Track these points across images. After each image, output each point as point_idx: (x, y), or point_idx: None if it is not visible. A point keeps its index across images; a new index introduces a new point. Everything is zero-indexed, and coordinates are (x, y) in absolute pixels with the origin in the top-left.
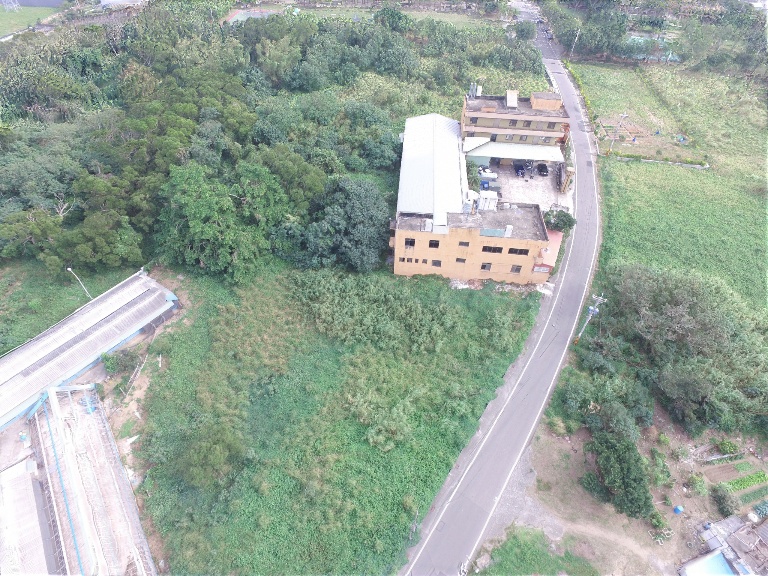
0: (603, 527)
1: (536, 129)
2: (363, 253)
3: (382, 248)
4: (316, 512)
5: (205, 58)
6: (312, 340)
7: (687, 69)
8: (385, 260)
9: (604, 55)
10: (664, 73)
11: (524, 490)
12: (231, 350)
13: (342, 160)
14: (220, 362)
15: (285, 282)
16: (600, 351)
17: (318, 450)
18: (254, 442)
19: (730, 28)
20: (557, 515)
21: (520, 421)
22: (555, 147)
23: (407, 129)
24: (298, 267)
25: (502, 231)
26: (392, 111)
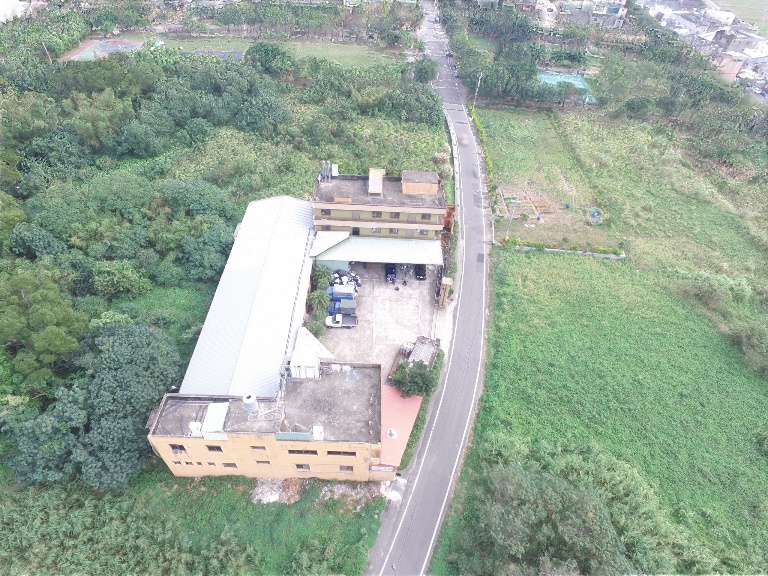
0: None
1: (408, 220)
2: (105, 467)
3: (147, 446)
4: None
5: None
6: None
7: (606, 115)
8: None
9: (515, 98)
10: (581, 120)
11: None
12: None
13: (145, 272)
14: None
15: None
16: None
17: None
18: None
19: (652, 65)
20: None
21: None
22: (434, 241)
23: (245, 220)
24: (17, 482)
25: (308, 434)
26: (239, 187)
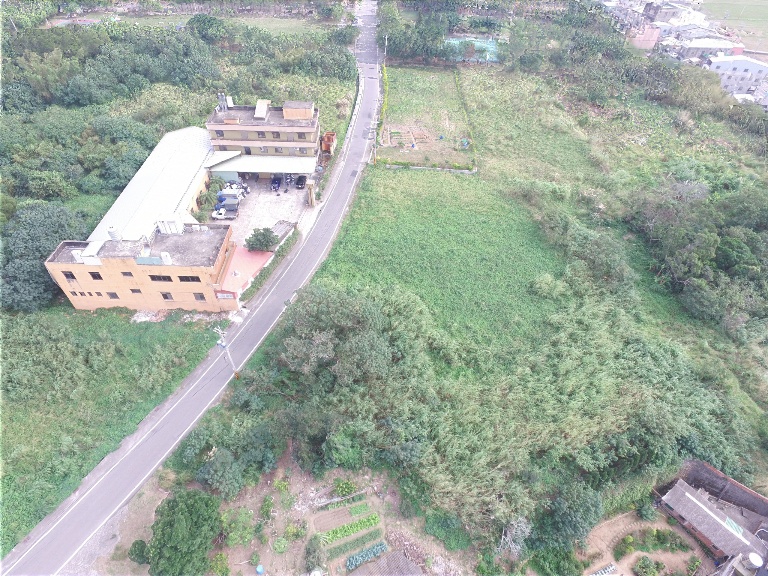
0: None
1: (287, 140)
2: (17, 290)
3: (52, 282)
4: None
5: None
6: None
7: (504, 70)
8: None
9: None
10: None
11: (92, 562)
12: None
13: (72, 182)
14: None
15: None
16: (248, 386)
17: None
18: None
19: (553, 28)
20: None
21: (129, 476)
22: (311, 158)
23: (159, 145)
24: None
25: (158, 259)
26: (162, 125)
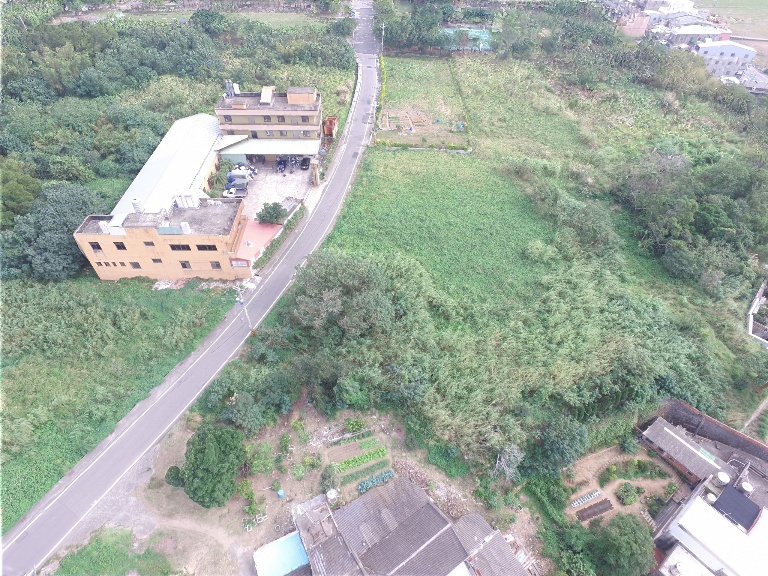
0: (199, 520)
1: (292, 124)
2: (48, 260)
3: (79, 254)
4: None
5: None
6: None
7: (497, 58)
8: None
9: None
10: (475, 62)
11: (131, 490)
12: None
13: (90, 166)
14: None
15: None
16: (264, 341)
17: None
18: None
19: (544, 16)
20: (155, 512)
21: (160, 419)
22: (315, 140)
23: (170, 131)
24: None
25: (178, 228)
26: (171, 113)
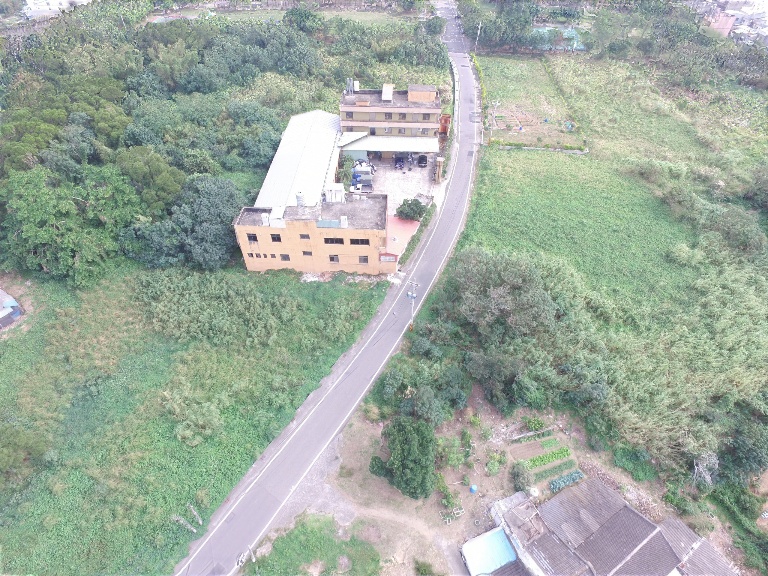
0: (396, 510)
1: (412, 121)
2: (206, 250)
3: (231, 245)
4: (104, 510)
5: (96, 64)
6: (148, 339)
7: (591, 57)
8: (241, 257)
9: (512, 47)
10: (569, 62)
11: (324, 477)
12: (63, 353)
13: (218, 160)
14: (49, 366)
15: (132, 283)
16: (428, 336)
17: (125, 448)
18: (63, 444)
19: (637, 16)
20: (352, 501)
21: (337, 409)
22: (433, 138)
23: (289, 126)
24: (148, 267)
25: (337, 222)
26: (282, 110)
